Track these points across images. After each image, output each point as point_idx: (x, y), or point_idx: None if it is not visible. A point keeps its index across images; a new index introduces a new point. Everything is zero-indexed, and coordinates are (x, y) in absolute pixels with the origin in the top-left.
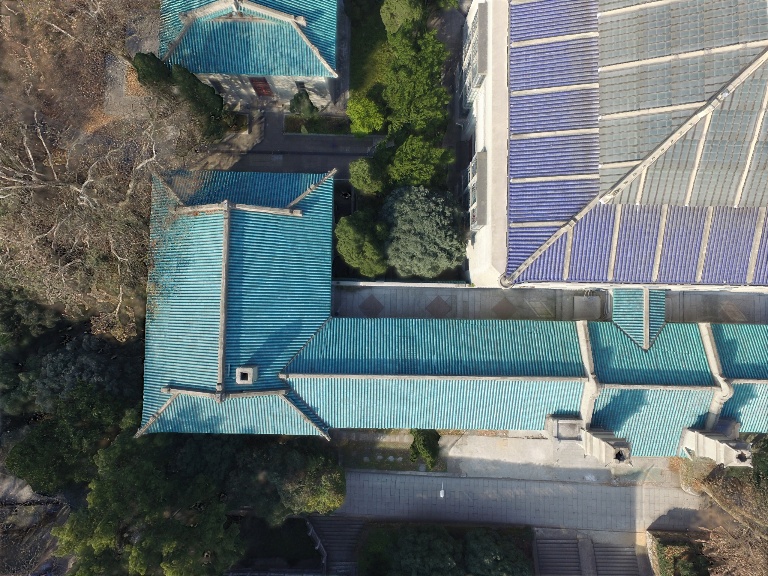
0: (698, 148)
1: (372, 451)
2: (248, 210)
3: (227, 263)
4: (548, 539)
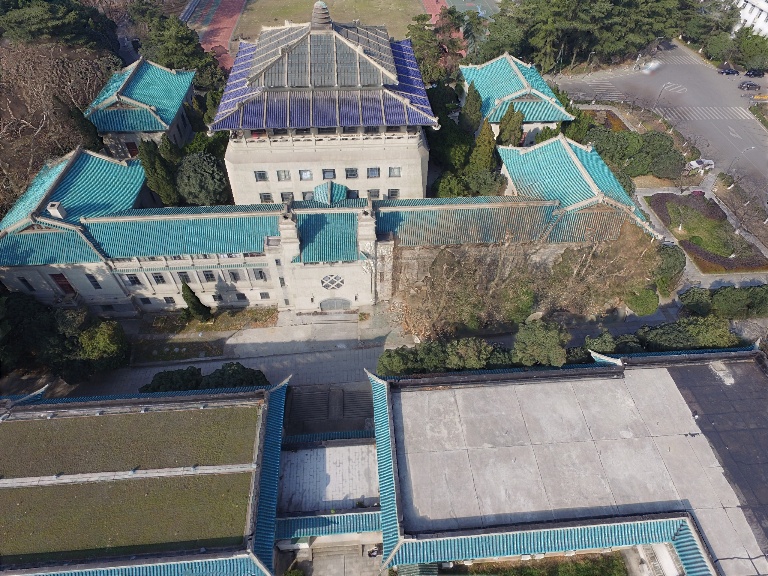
0: (285, 66)
1: (161, 346)
2: (92, 155)
3: (68, 168)
4: (304, 393)
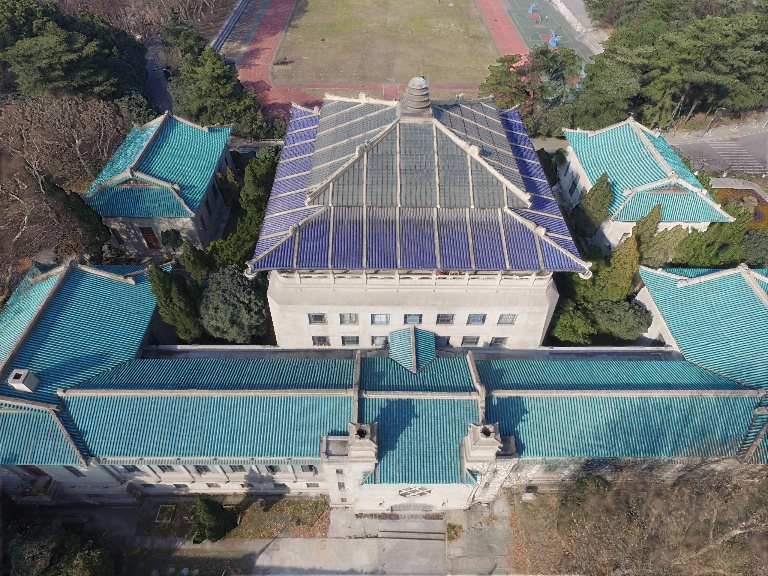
0: (363, 173)
1: (165, 561)
2: (88, 271)
3: (51, 299)
4: None
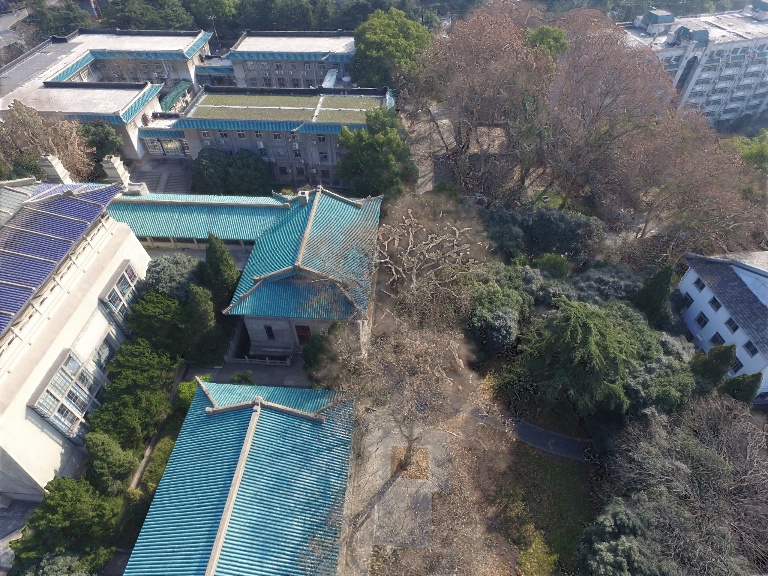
0: None
1: None
2: None
3: None
4: None
